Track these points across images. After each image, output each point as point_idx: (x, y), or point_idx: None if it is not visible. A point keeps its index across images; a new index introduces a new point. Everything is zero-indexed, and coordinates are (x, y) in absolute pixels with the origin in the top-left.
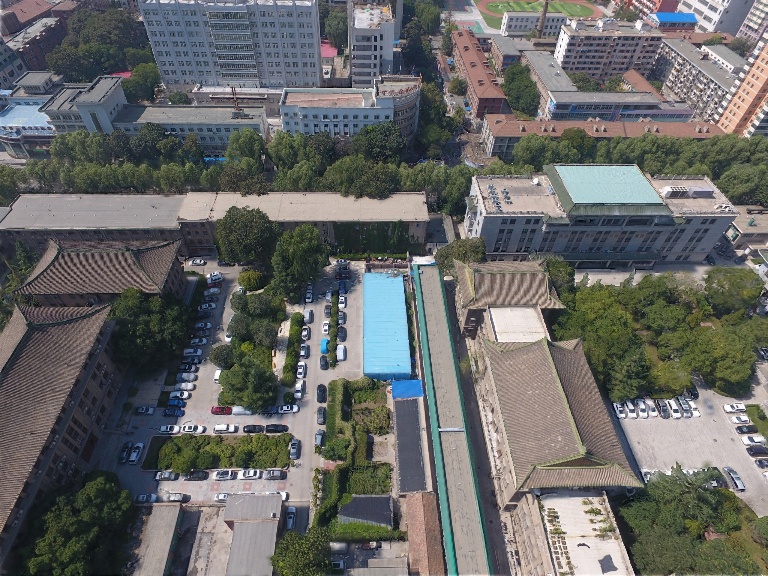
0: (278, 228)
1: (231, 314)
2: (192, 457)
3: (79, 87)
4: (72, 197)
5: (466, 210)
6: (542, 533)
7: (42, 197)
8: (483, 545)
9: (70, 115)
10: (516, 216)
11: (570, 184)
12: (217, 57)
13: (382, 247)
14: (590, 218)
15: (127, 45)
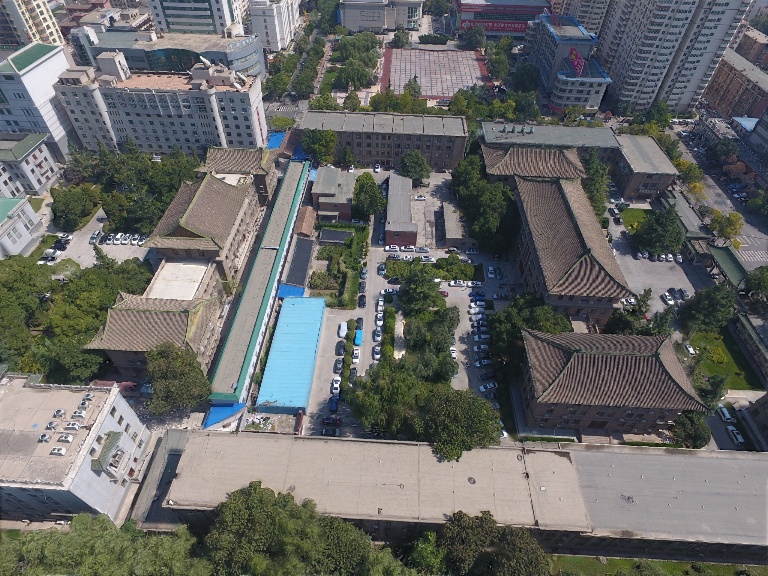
0: (414, 421)
1: (460, 379)
2: (449, 258)
3: None
4: None
5: (100, 512)
6: None
7: None
8: None
9: None
10: None
11: None
12: None
13: None
14: None
15: None
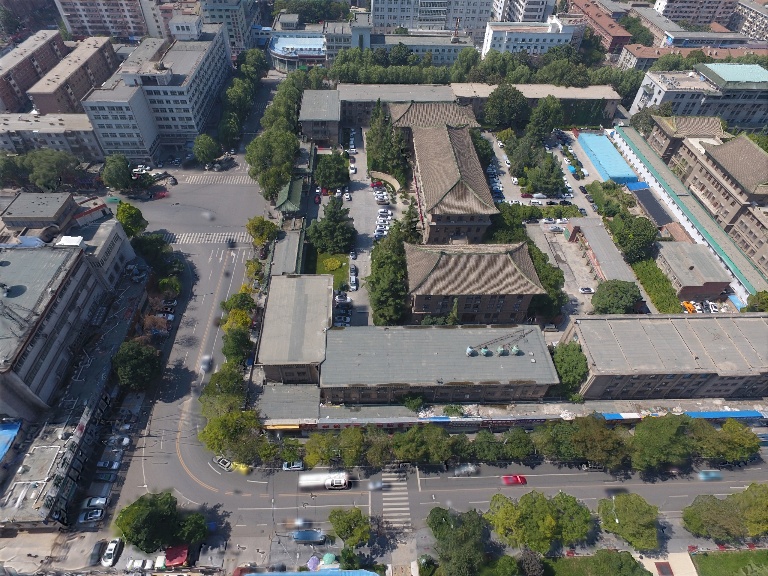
0: (527, 100)
1: (501, 155)
2: (531, 209)
3: (336, 21)
4: (373, 86)
5: (634, 100)
6: (765, 217)
7: (352, 85)
8: (725, 234)
9: (341, 38)
10: (687, 91)
11: (719, 72)
12: (419, 4)
13: (584, 121)
14: (734, 94)
15: (330, 0)
